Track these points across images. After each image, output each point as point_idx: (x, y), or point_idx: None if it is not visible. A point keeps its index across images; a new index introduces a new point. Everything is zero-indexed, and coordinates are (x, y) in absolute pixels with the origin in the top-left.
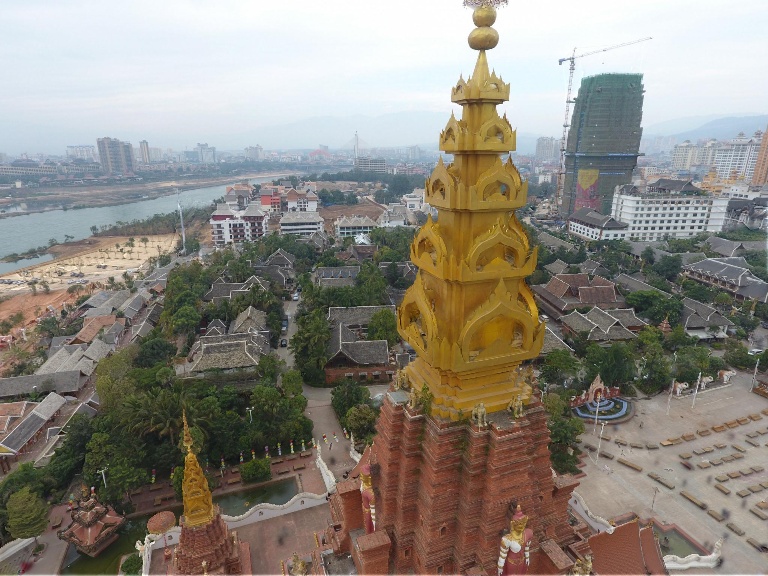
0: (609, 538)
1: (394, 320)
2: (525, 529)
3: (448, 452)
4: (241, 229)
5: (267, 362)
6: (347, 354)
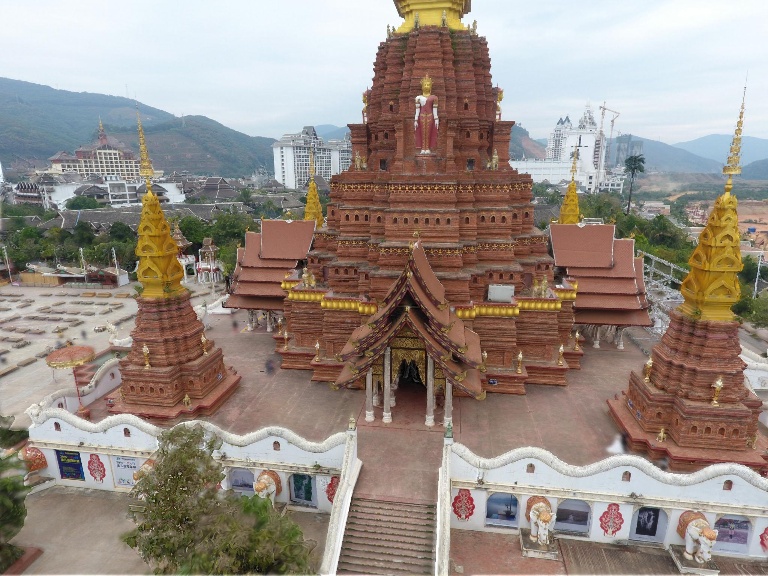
0: None
1: None
2: None
3: None
4: None
5: None
6: None
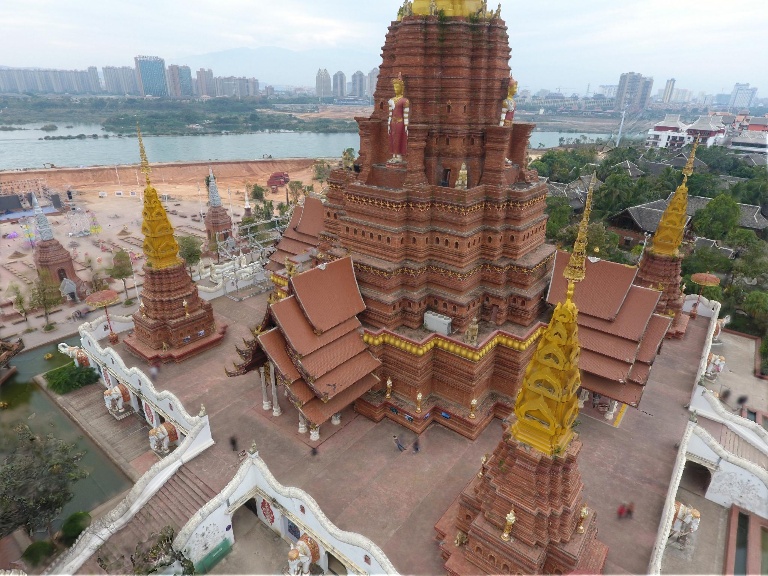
0: (589, 266)
1: (734, 213)
2: (405, 98)
3: (392, 44)
4: (680, 143)
5: (554, 198)
6: (633, 215)
